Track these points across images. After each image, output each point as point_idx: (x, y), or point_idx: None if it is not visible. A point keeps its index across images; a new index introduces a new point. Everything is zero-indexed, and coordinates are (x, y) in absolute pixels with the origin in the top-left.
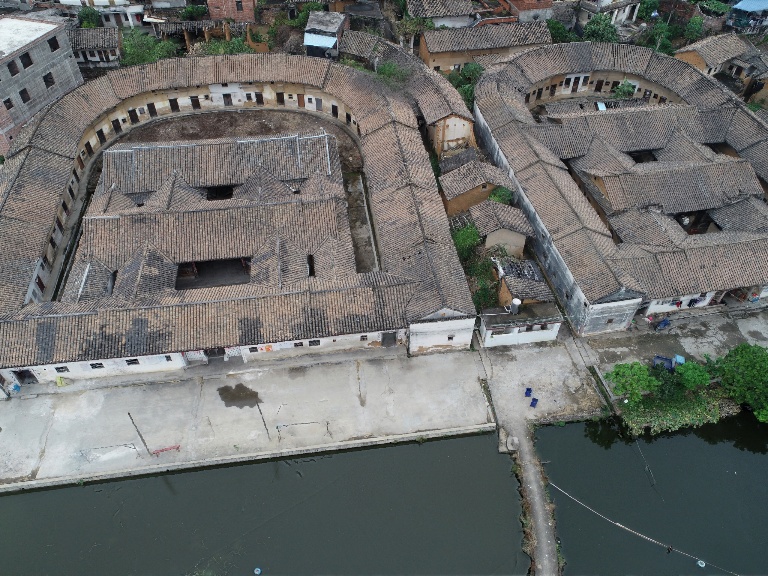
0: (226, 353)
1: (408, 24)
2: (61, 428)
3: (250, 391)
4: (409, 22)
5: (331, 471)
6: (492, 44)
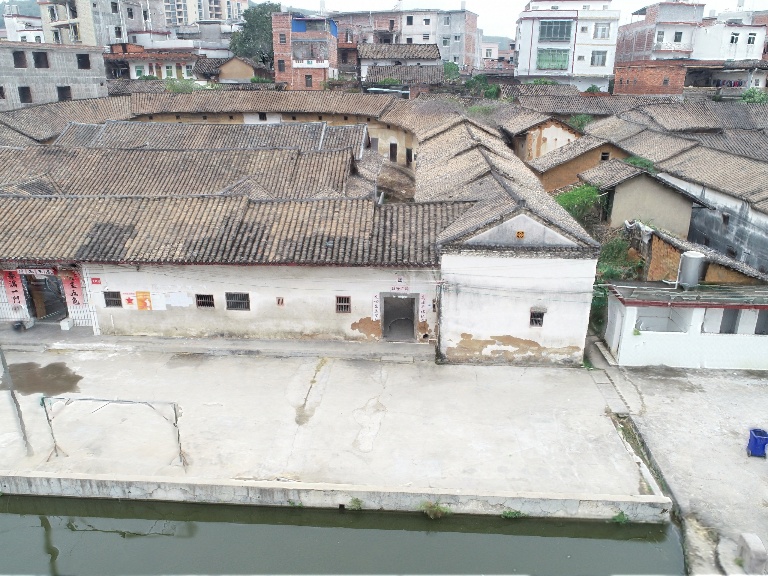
0: (70, 315)
1: None
2: None
3: (70, 373)
4: (501, 101)
5: (143, 559)
6: (607, 110)
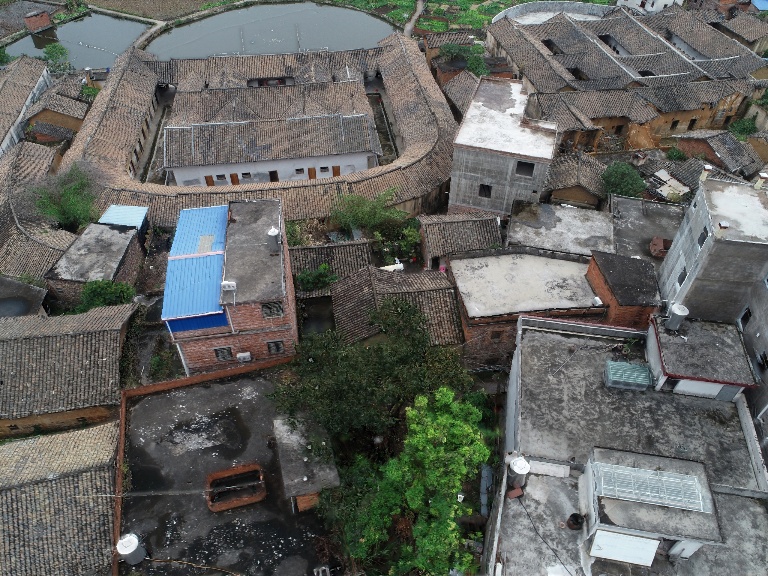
0: None
1: None
2: None
3: None
4: None
5: None
6: None
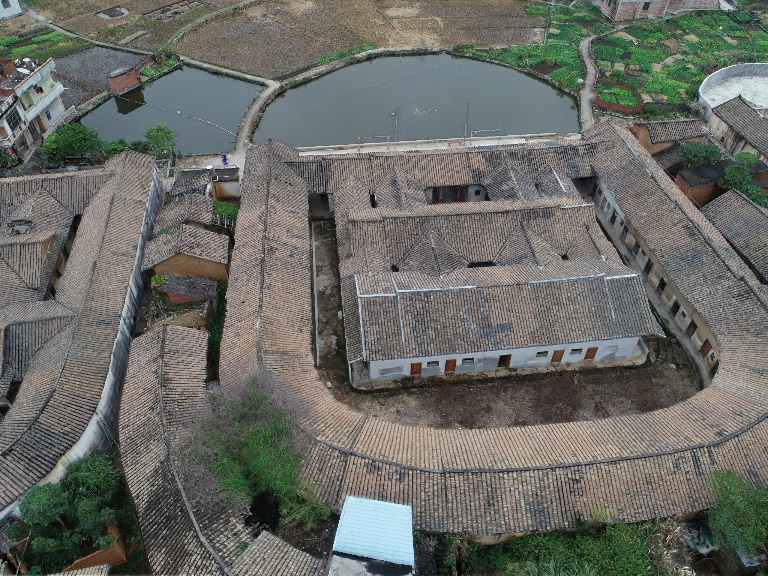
0: None
1: None
2: None
3: None
4: None
5: None
6: None
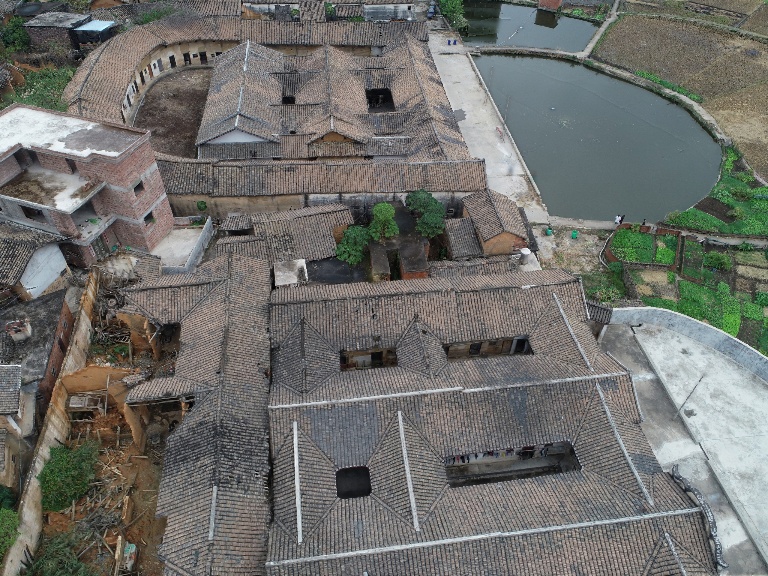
0: None
1: (70, 3)
2: (489, 172)
3: None
4: None
5: (496, 96)
6: None
